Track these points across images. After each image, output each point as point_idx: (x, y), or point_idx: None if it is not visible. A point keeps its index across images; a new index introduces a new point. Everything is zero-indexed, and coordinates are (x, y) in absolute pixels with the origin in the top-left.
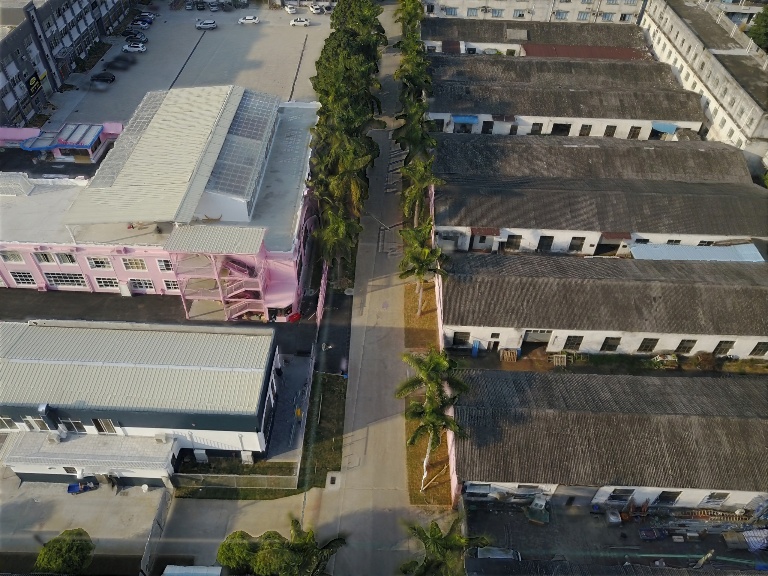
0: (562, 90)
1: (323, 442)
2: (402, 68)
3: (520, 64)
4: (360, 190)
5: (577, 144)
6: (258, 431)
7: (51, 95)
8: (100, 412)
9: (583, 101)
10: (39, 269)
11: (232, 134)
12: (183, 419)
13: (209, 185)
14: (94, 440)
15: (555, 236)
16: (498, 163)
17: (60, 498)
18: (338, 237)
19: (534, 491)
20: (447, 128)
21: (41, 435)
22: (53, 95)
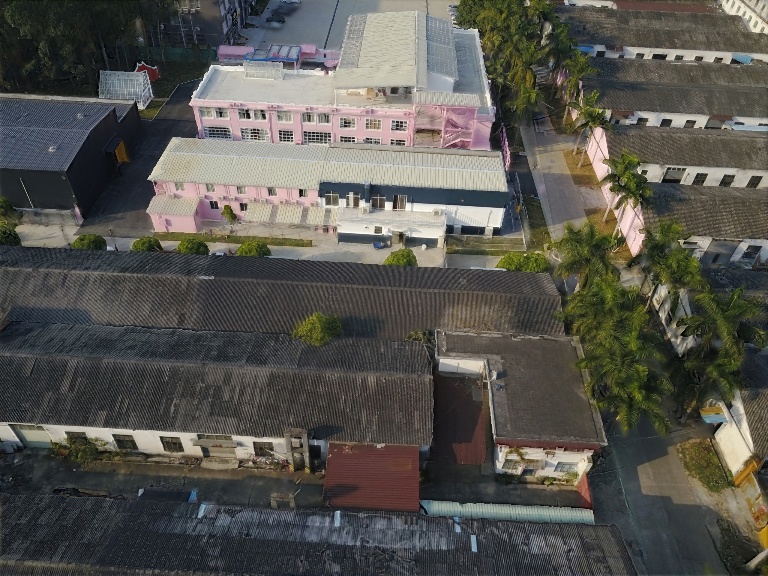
0: (659, 29)
1: (535, 229)
2: None
3: (619, 12)
4: None
5: (680, 62)
6: None
7: (240, 30)
8: (404, 188)
9: (677, 37)
10: (301, 128)
11: (429, 40)
12: (457, 195)
13: (429, 68)
14: (391, 213)
15: (673, 119)
16: (621, 74)
17: (368, 251)
18: (529, 103)
19: (694, 246)
20: None
21: (354, 209)
22: (241, 30)
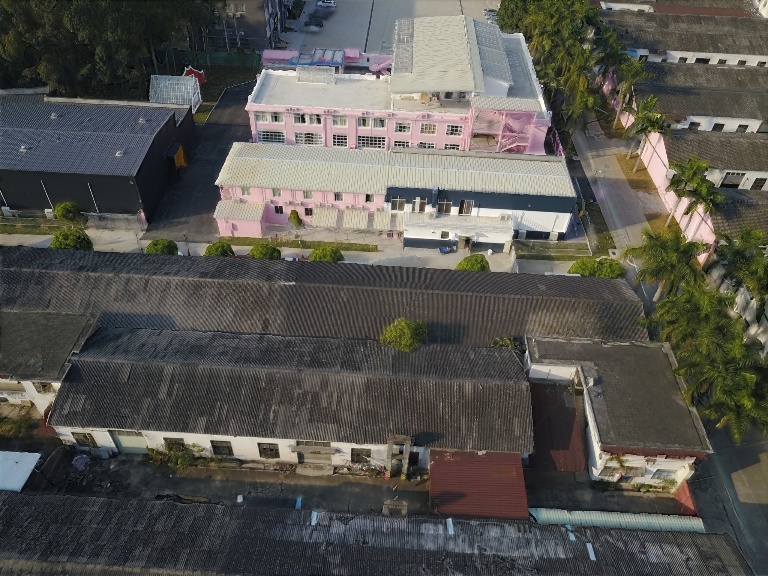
0: (702, 33)
1: (598, 234)
2: None
3: (659, 16)
4: (587, 82)
5: (727, 67)
6: (571, 212)
7: (279, 34)
8: (472, 193)
9: (720, 41)
10: (356, 132)
11: (480, 45)
12: (525, 200)
13: (484, 73)
14: (457, 218)
15: (726, 124)
16: (668, 78)
17: (434, 256)
18: (586, 107)
19: None
20: None
21: (420, 214)
22: (281, 34)
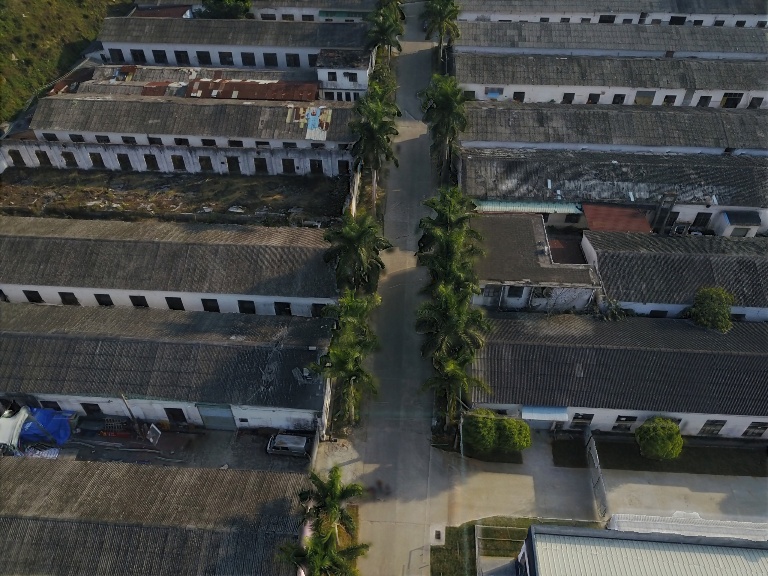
0: None
1: None
2: None
3: None
4: None
5: None
6: None
7: None
8: (715, 537)
9: None
10: None
11: None
12: None
13: None
14: None
15: None
16: None
17: None
18: None
19: None
20: None
21: None
22: None
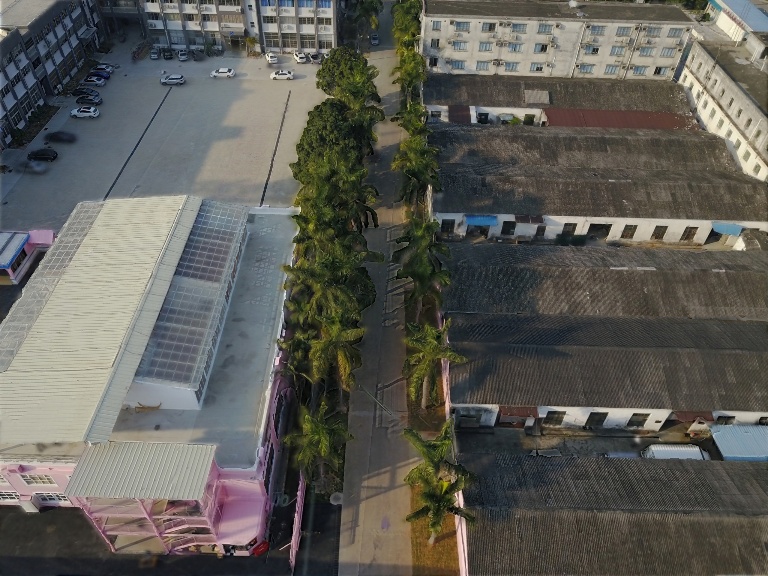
0: (600, 181)
1: None
2: (401, 137)
3: (544, 140)
4: (350, 364)
5: (627, 265)
6: None
7: None
8: None
9: (626, 195)
10: None
11: (180, 275)
12: None
13: (141, 369)
14: None
15: (610, 412)
16: (528, 294)
17: None
18: (319, 453)
19: None
20: (459, 229)
21: None
22: None
